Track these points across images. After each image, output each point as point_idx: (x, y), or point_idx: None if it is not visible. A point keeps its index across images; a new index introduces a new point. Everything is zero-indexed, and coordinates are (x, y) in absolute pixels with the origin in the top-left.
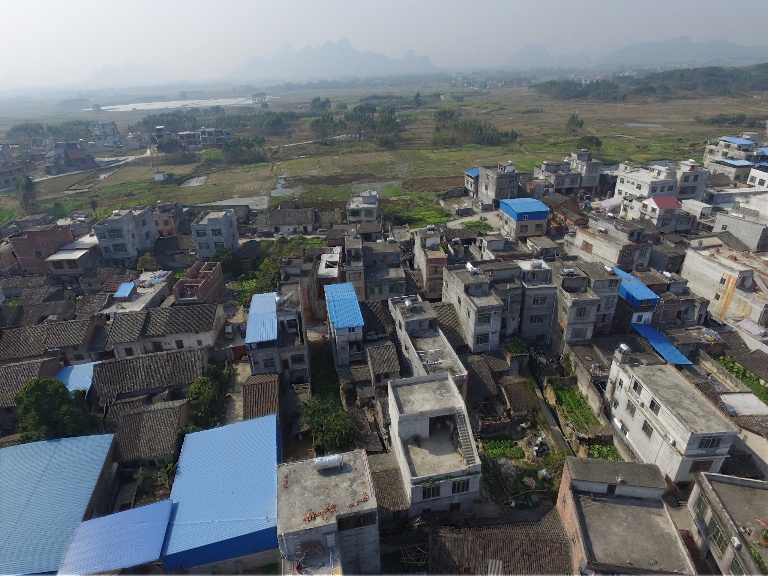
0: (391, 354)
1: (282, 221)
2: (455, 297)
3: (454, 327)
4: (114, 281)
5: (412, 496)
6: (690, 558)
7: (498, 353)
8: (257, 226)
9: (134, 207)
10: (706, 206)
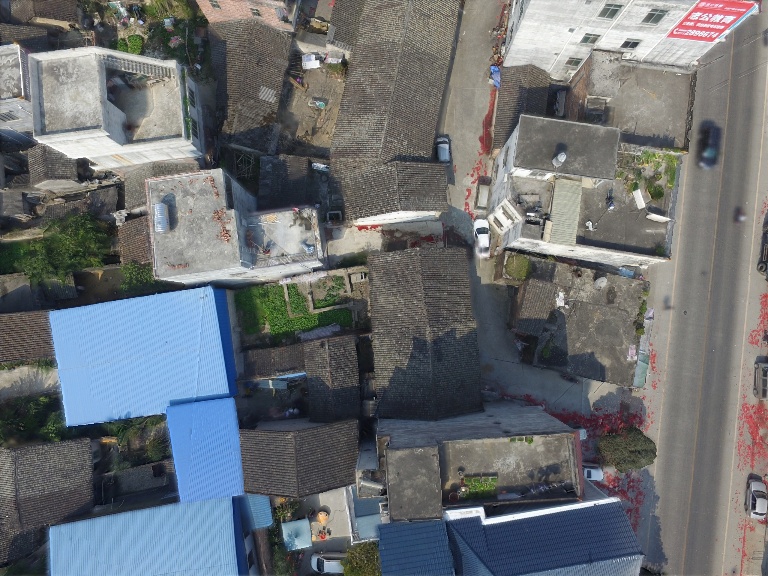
0: None
1: None
2: None
3: None
4: None
5: (196, 148)
6: None
7: None
8: None
9: None
10: None
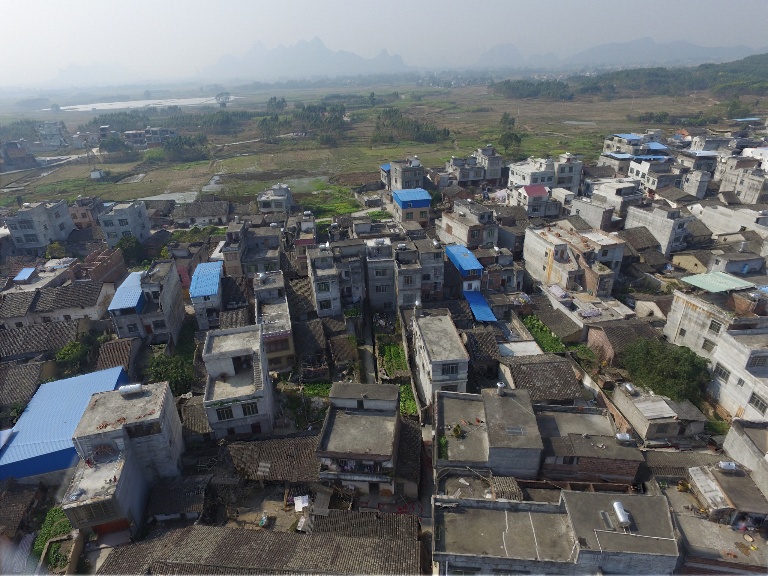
0: (239, 318)
1: (197, 213)
2: (310, 271)
3: (307, 297)
4: (20, 267)
5: (208, 417)
6: (392, 445)
7: (339, 317)
8: (174, 218)
9: (49, 201)
10: (569, 193)
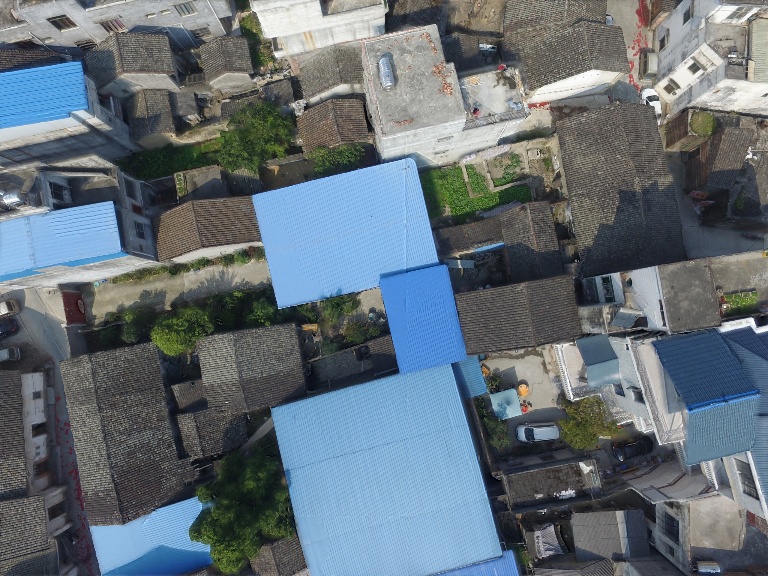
0: (136, 41)
1: None
2: None
3: None
4: None
5: (384, 22)
6: None
7: None
8: None
9: None
10: None
